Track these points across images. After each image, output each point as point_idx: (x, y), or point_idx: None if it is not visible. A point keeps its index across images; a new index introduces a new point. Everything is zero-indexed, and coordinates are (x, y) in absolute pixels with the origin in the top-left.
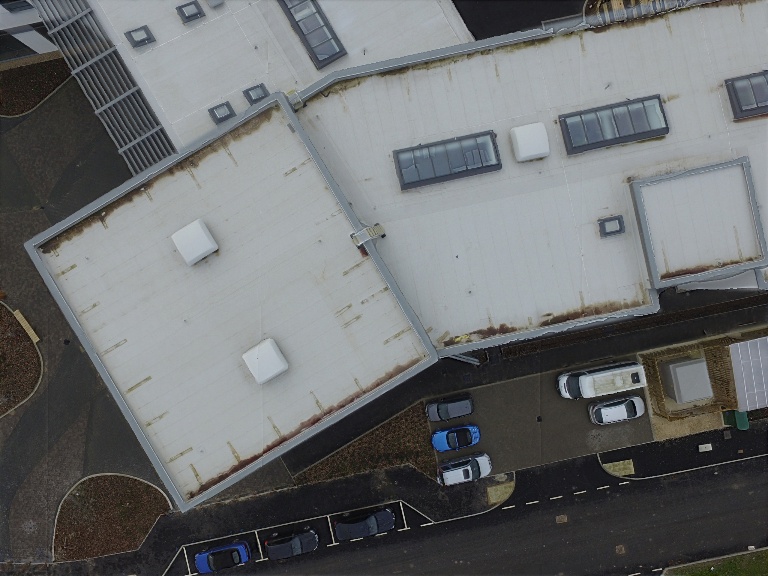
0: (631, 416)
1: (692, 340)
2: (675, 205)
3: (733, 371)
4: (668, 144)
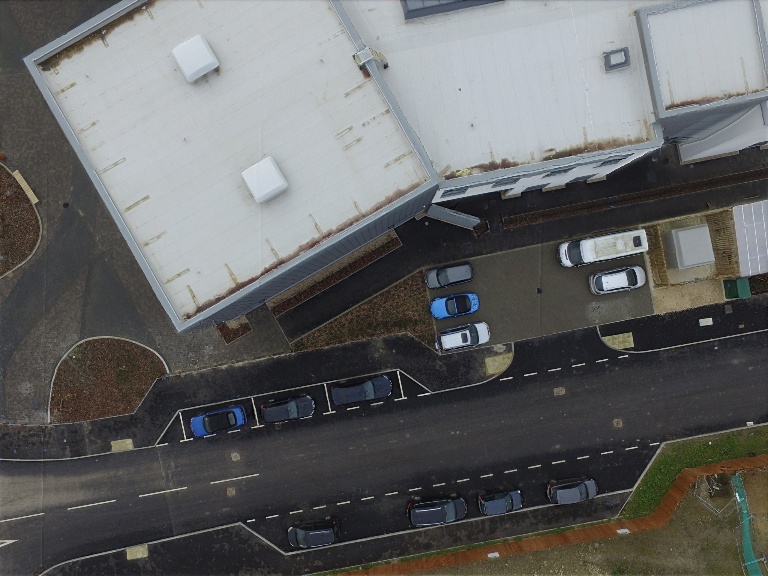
0: (632, 284)
1: (695, 213)
2: (682, 35)
3: (736, 234)
4: None
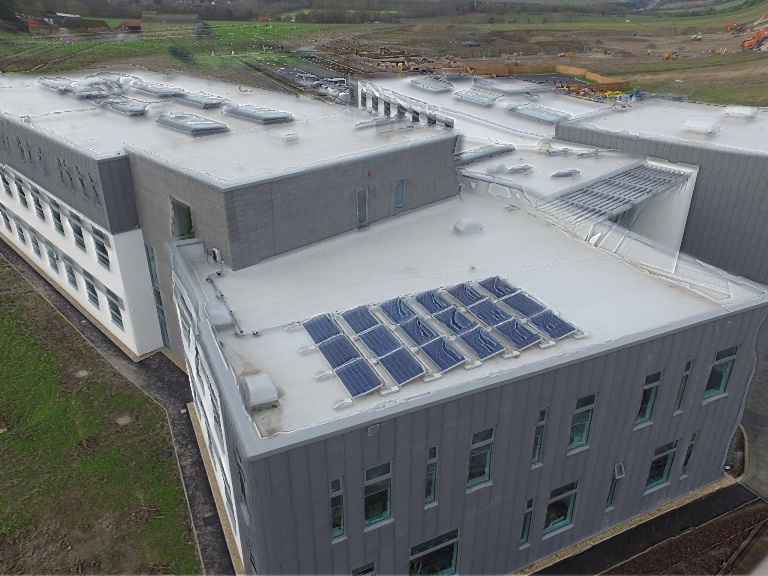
0: None
1: None
2: None
3: None
4: None
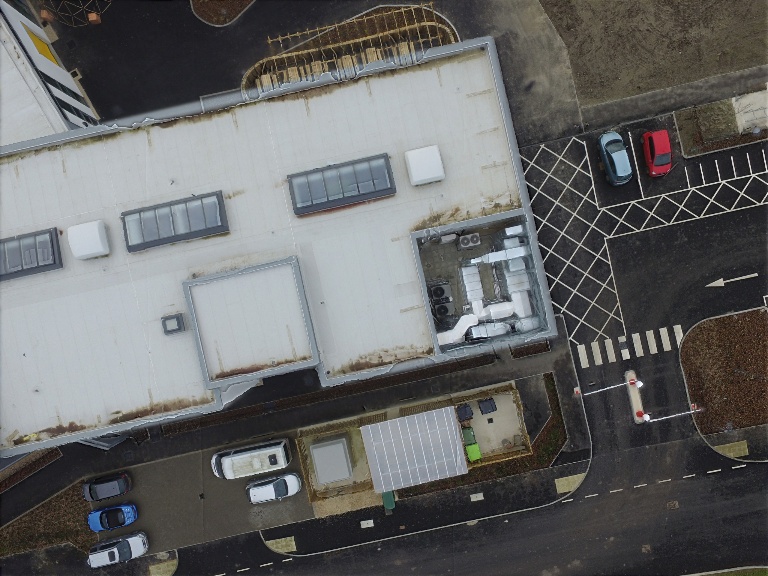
0: (282, 495)
1: (352, 416)
2: (227, 304)
3: (366, 453)
4: (231, 240)
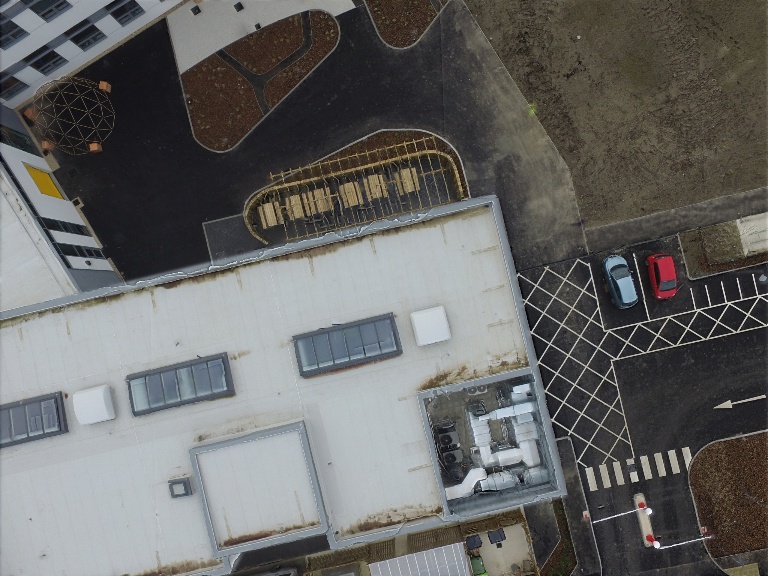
0: None
1: None
2: (235, 471)
3: None
4: (237, 403)
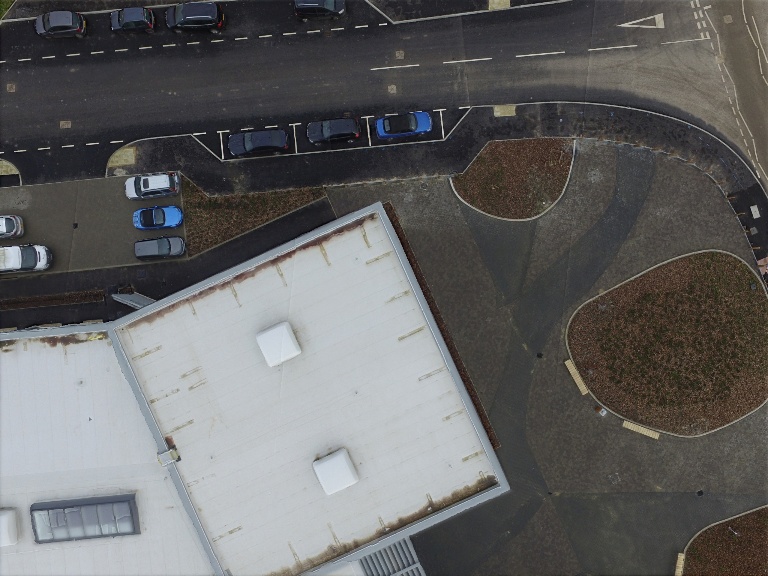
0: None
1: None
2: None
3: None
4: None
